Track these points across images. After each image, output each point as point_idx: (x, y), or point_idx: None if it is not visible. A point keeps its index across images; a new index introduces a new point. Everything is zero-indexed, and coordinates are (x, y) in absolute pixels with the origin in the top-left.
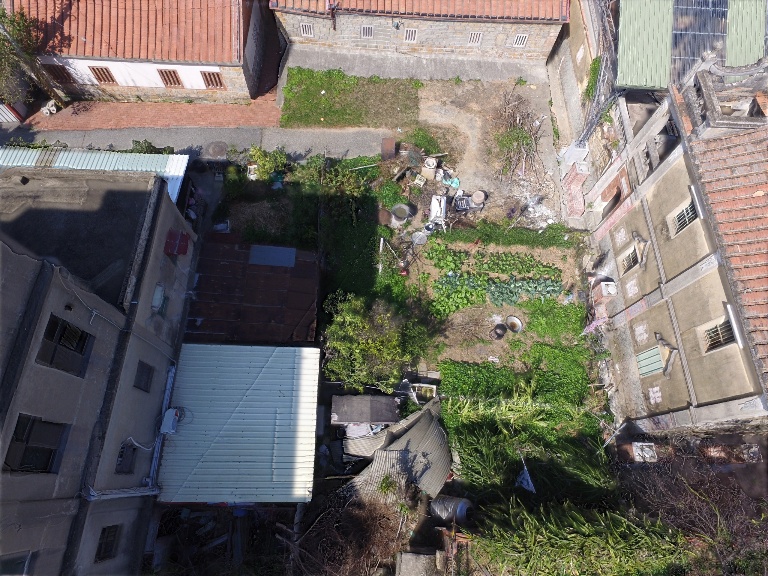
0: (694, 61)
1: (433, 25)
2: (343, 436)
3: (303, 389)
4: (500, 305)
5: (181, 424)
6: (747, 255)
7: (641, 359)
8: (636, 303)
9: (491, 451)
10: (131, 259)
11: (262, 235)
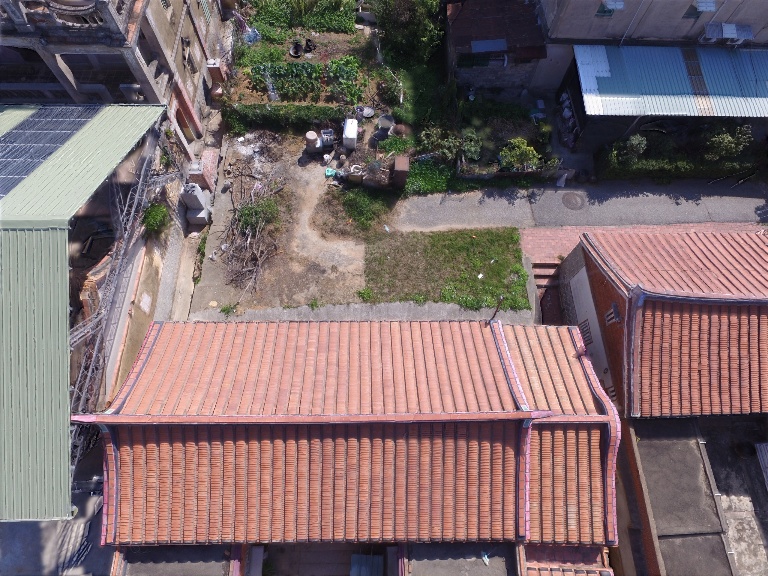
0: (65, 118)
1: None
2: None
3: None
4: None
5: None
6: None
7: None
8: None
9: None
10: None
11: (503, 107)
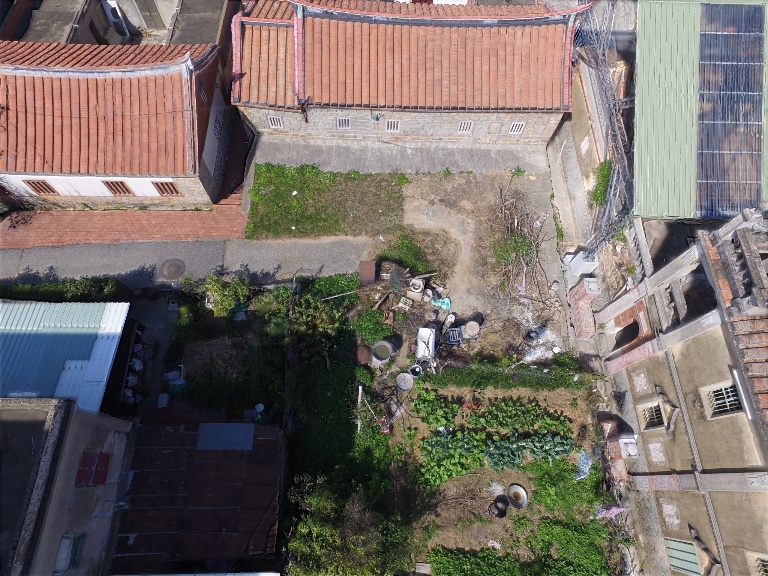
0: (724, 185)
1: (417, 116)
2: None
3: None
4: (500, 470)
5: None
6: None
7: (671, 546)
8: (663, 475)
9: None
10: (15, 538)
11: (220, 386)
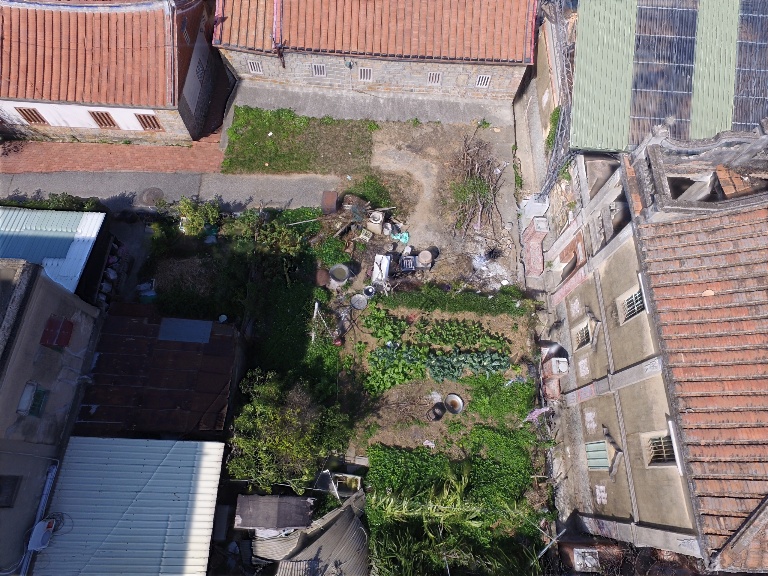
0: (655, 121)
1: (388, 65)
2: (252, 536)
3: (201, 491)
4: (441, 381)
5: (59, 533)
6: (691, 366)
7: (589, 450)
8: (586, 386)
9: (410, 563)
10: None
11: (187, 297)
